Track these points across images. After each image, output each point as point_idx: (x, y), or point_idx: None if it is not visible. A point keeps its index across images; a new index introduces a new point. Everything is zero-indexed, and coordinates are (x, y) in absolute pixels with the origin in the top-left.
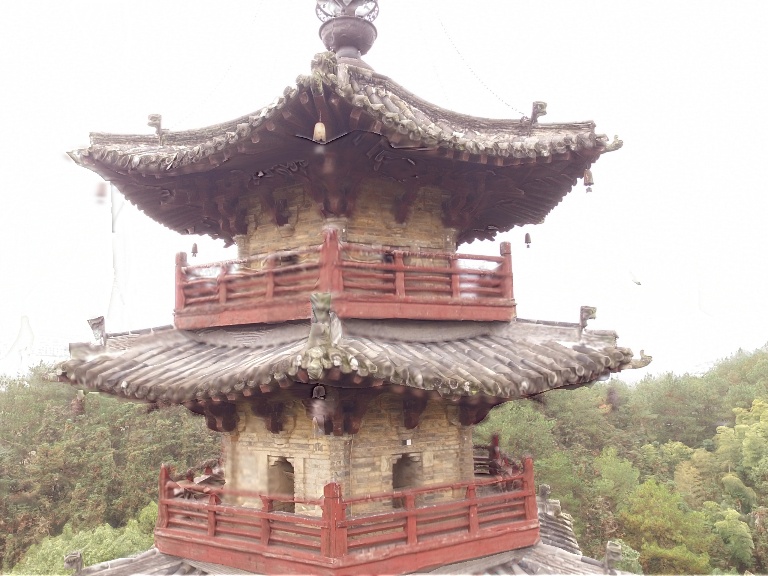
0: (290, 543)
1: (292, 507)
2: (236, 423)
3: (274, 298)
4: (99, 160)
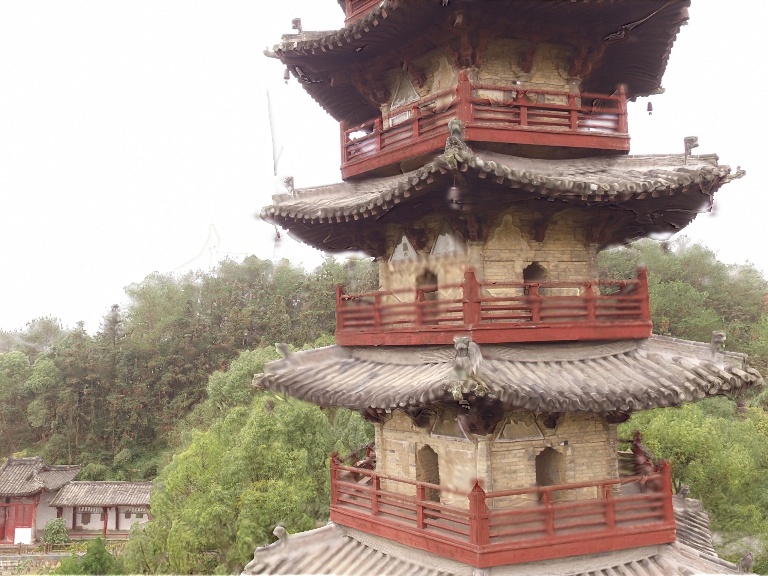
0: None
1: None
2: None
3: None
4: None
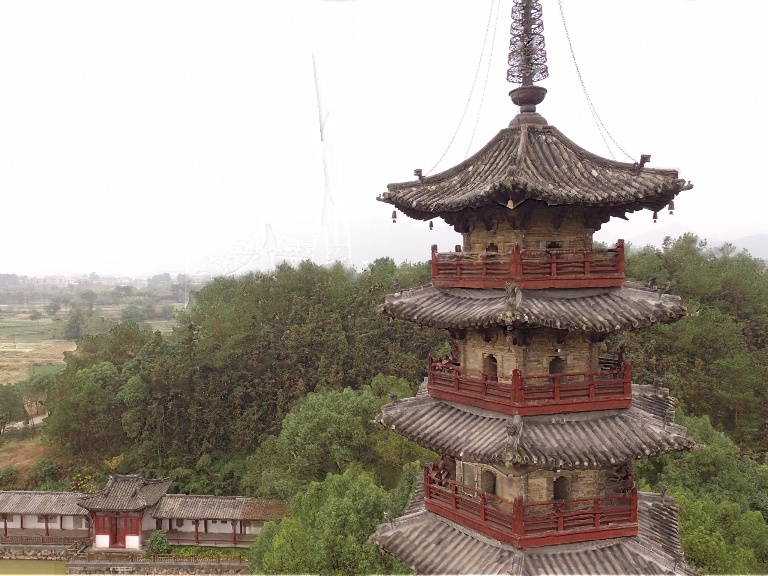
0: (496, 395)
1: (497, 379)
2: (465, 335)
3: (487, 276)
4: (394, 201)
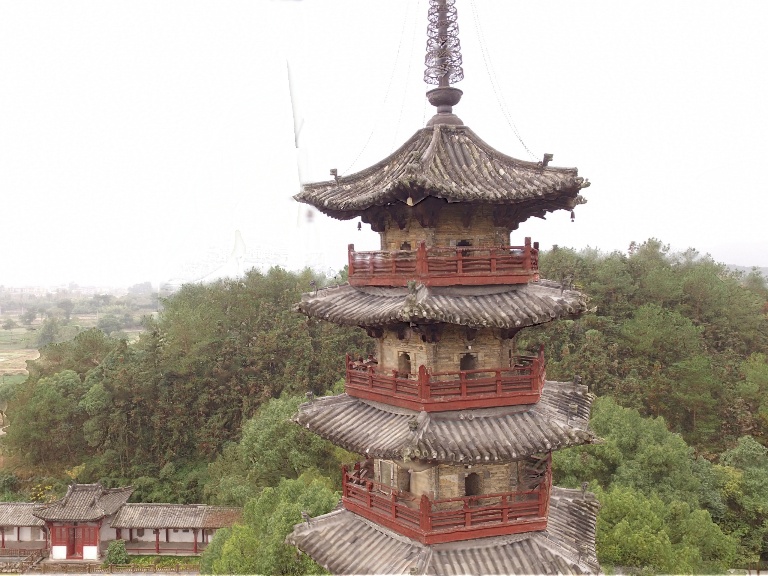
0: (405, 392)
1: (407, 376)
2: (382, 334)
3: (396, 274)
4: (308, 200)
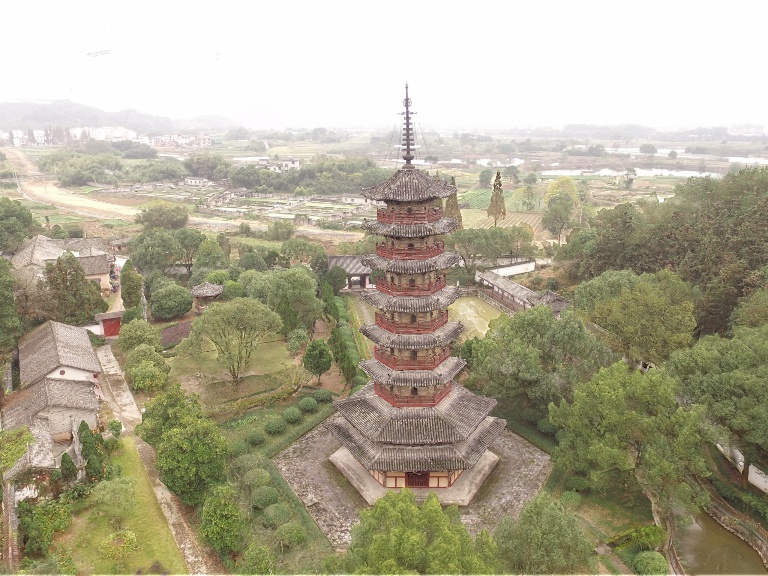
0: None
1: None
2: None
3: None
4: None
